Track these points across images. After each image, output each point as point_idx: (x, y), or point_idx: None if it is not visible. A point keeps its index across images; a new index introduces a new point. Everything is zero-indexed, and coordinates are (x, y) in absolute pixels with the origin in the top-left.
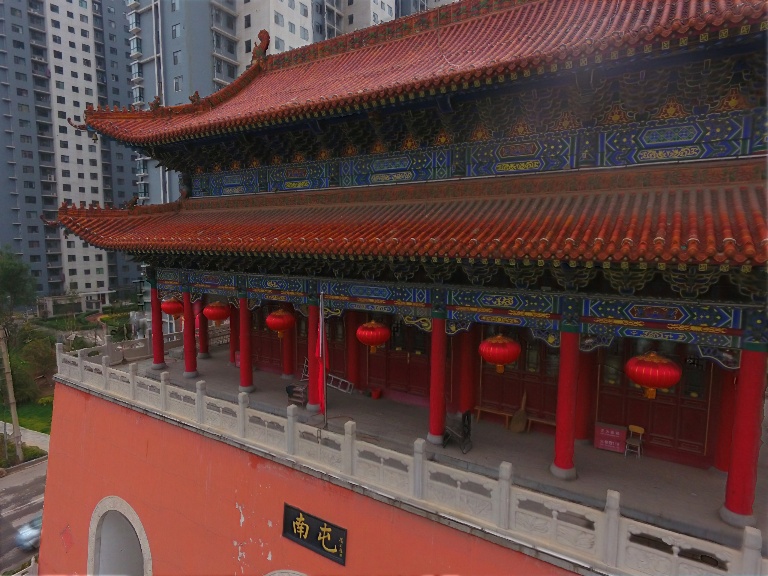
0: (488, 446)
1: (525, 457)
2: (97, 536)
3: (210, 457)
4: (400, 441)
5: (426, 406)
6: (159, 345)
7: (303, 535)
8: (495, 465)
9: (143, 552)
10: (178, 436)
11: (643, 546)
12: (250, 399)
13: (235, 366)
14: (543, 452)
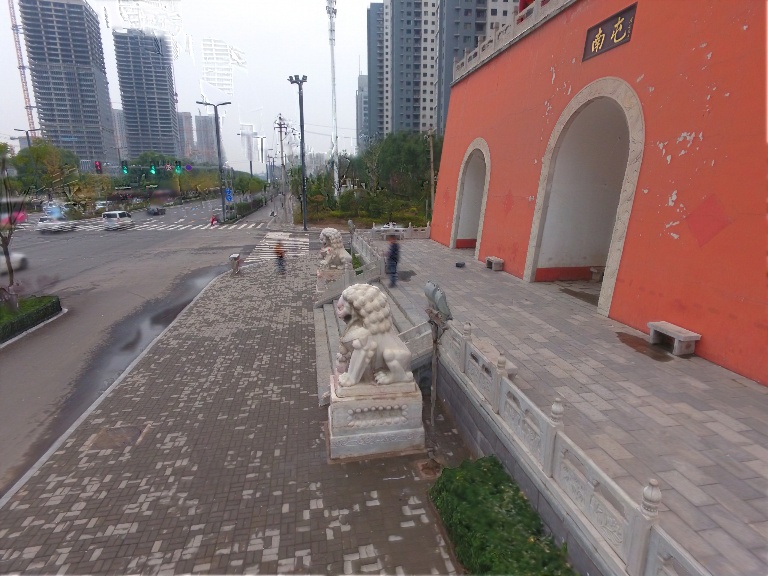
0: None
1: None
2: (462, 181)
3: (538, 46)
4: None
5: None
6: None
7: (599, 47)
8: None
9: (486, 167)
10: (518, 51)
11: None
12: None
13: None
14: None
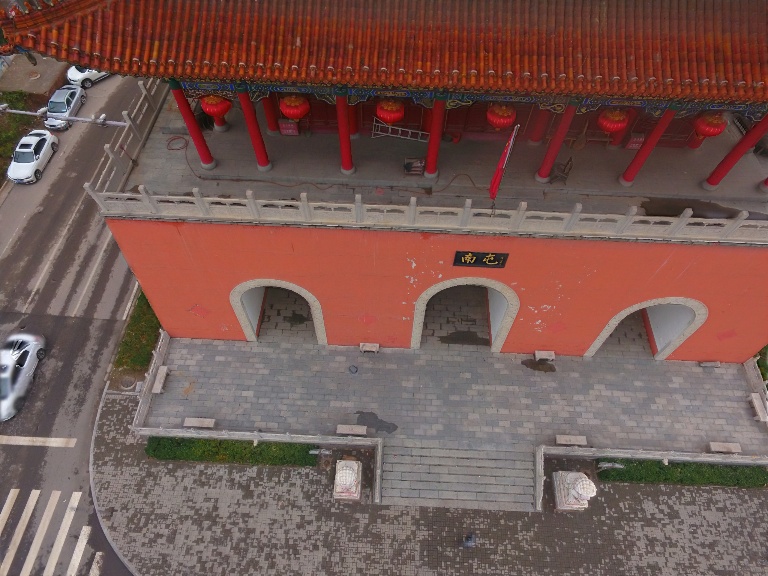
0: (571, 171)
1: (597, 174)
2: (241, 302)
3: (377, 240)
4: (518, 187)
5: (501, 140)
6: (204, 145)
7: (470, 262)
8: (588, 188)
9: (307, 299)
10: (334, 234)
11: (691, 226)
12: (363, 180)
13: (281, 134)
14: (603, 165)
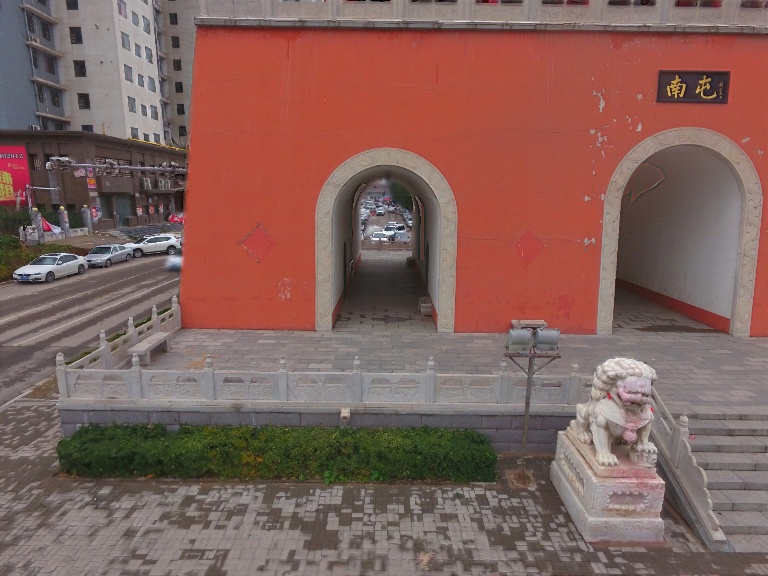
0: None
1: None
2: (332, 215)
3: (553, 54)
4: None
5: None
6: None
7: (679, 94)
8: None
9: (438, 196)
10: (497, 43)
11: None
12: None
13: None
14: None
